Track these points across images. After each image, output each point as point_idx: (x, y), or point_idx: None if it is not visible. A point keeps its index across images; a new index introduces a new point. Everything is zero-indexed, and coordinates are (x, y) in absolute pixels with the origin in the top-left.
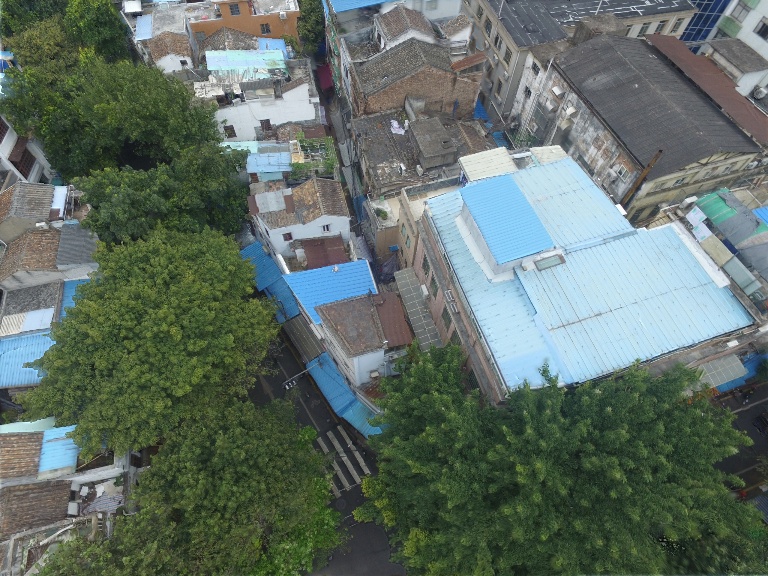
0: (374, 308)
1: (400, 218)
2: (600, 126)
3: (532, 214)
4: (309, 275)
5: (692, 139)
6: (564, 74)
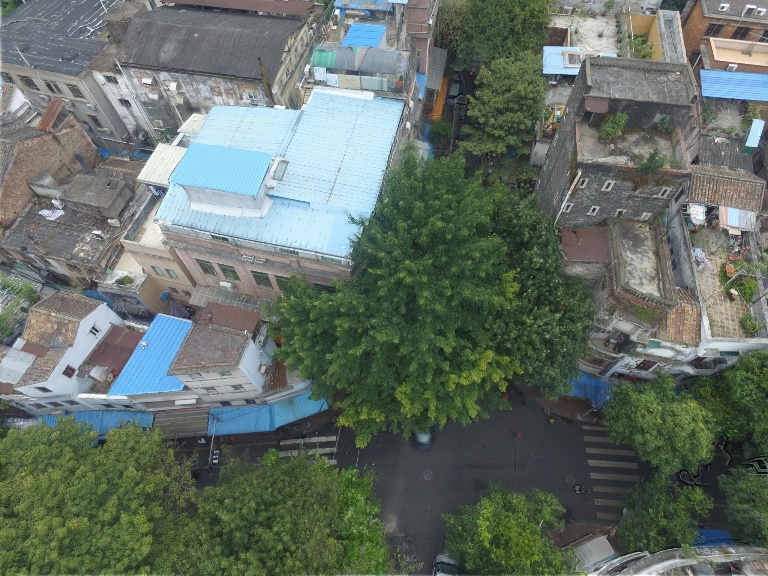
0: (210, 325)
1: (144, 266)
2: (205, 78)
3: (237, 151)
4: (128, 371)
5: (266, 40)
6: (138, 65)
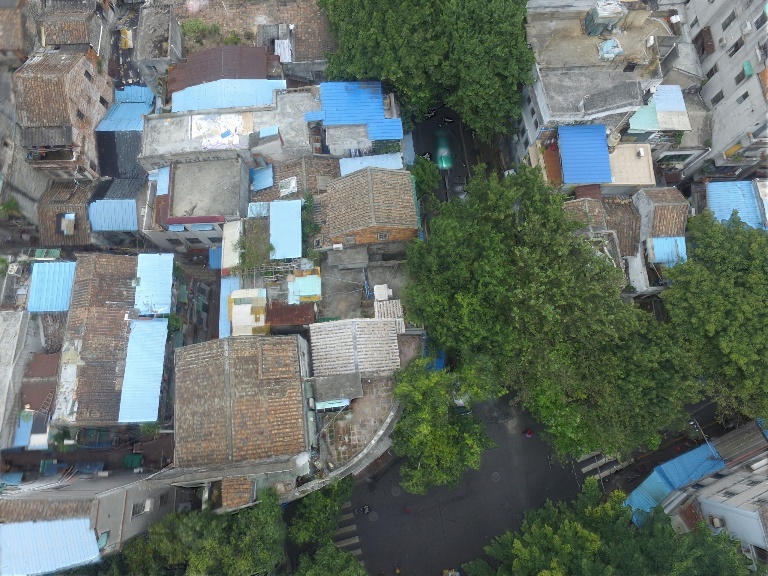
0: None
1: None
2: None
3: None
4: None
5: None
6: None
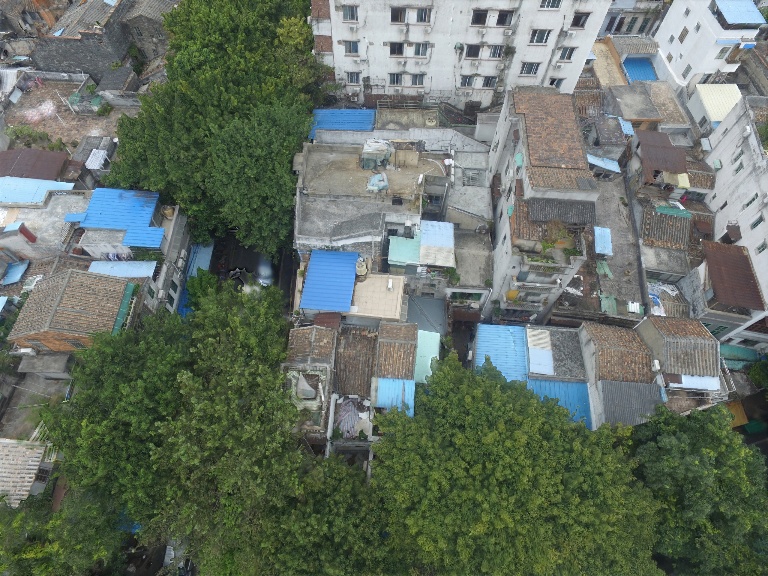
0: None
1: None
2: None
3: None
4: None
5: None
6: None
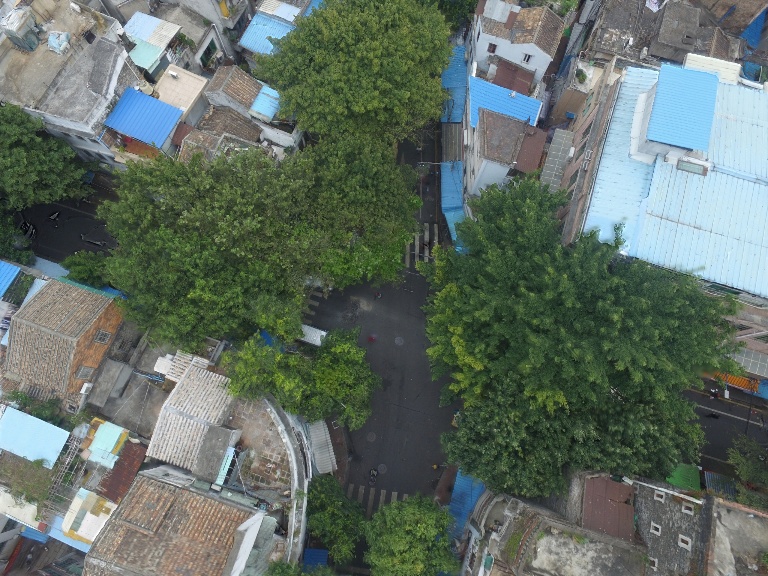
0: (523, 134)
1: (594, 86)
2: None
3: (709, 117)
4: (489, 87)
5: None
6: None
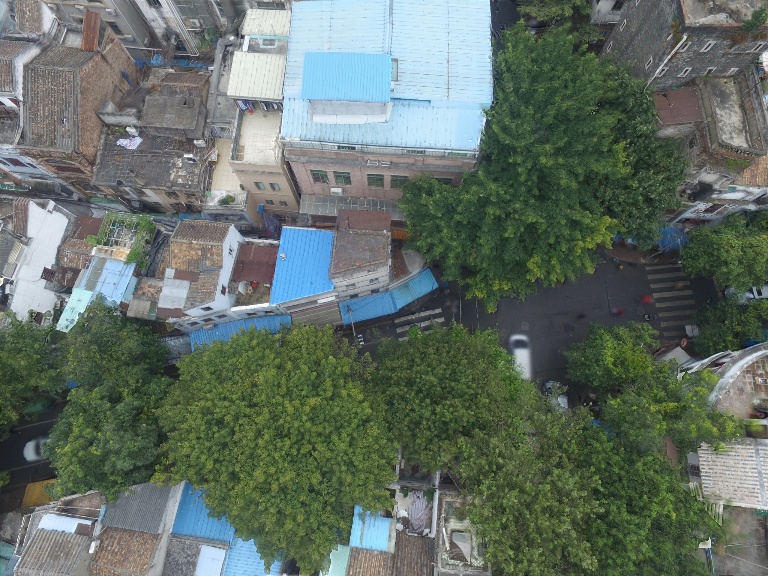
0: (350, 230)
1: (246, 183)
2: None
3: (355, 56)
4: (279, 281)
5: None
6: None
